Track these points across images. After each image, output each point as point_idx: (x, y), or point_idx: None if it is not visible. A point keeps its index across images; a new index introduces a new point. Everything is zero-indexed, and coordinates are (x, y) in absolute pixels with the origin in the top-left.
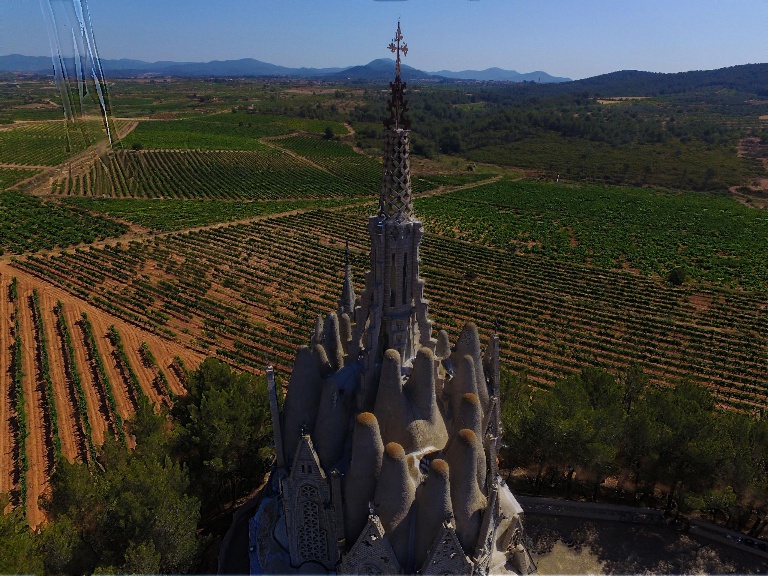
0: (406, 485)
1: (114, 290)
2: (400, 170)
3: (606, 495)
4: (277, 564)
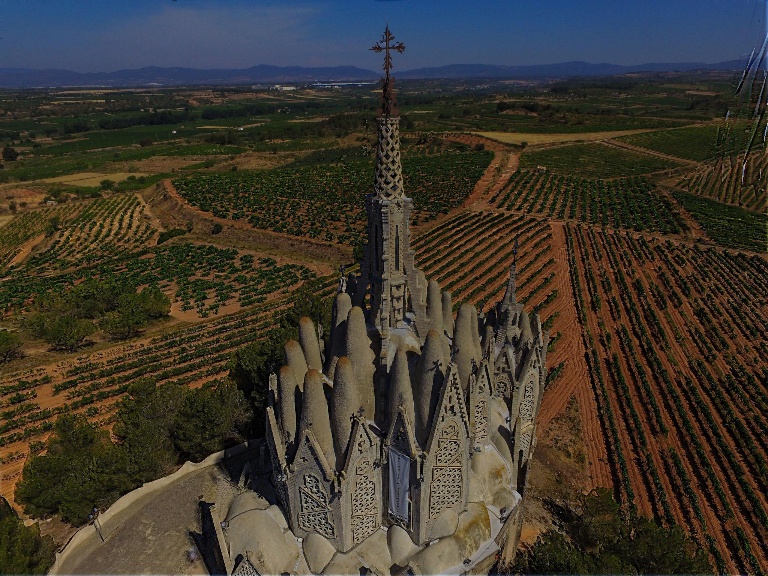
0: None
1: (598, 270)
2: (378, 152)
3: None
4: None
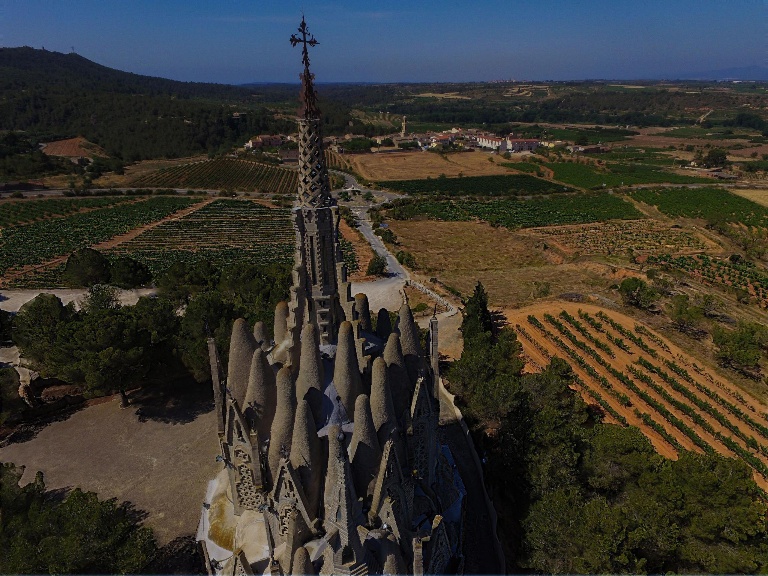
0: None
1: None
2: None
3: None
4: None
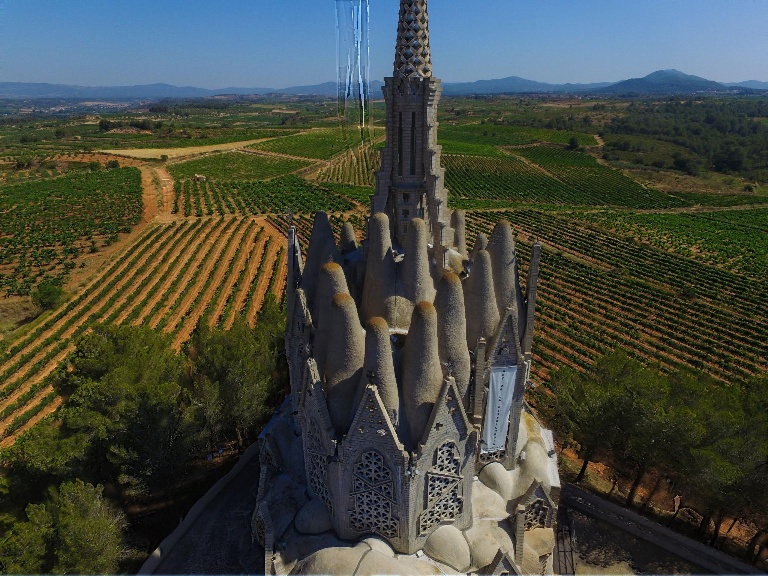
0: (351, 342)
1: None
2: (410, 15)
3: (758, 567)
4: (282, 424)
